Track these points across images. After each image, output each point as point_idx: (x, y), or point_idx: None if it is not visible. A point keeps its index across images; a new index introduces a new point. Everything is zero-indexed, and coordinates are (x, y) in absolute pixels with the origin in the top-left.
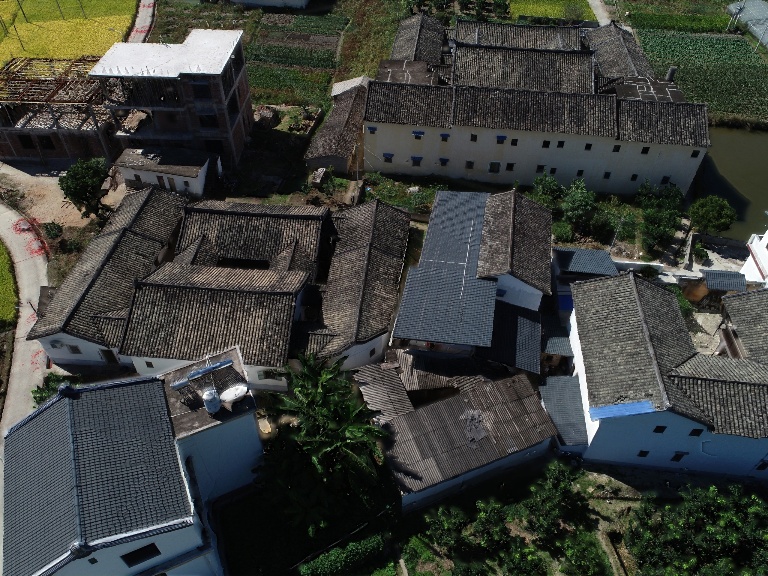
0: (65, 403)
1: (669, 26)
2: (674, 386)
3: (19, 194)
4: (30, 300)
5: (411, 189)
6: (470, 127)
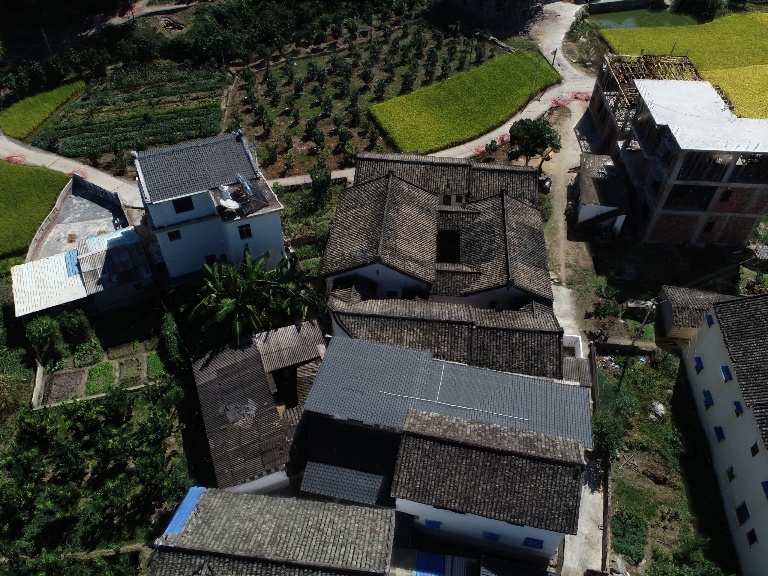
0: (233, 137)
1: None
2: (190, 571)
3: (546, 127)
4: None
5: (658, 405)
6: (760, 431)
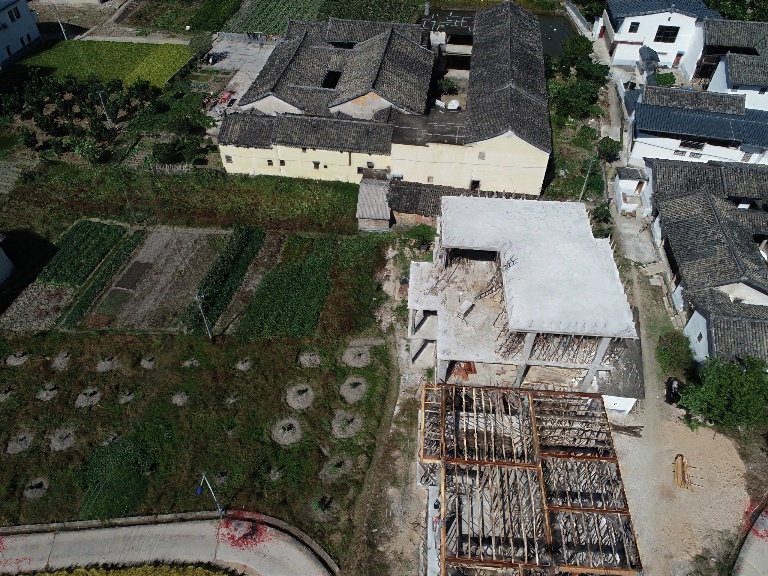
0: None
1: (224, 17)
2: None
3: (699, 567)
4: None
5: (564, 174)
6: None
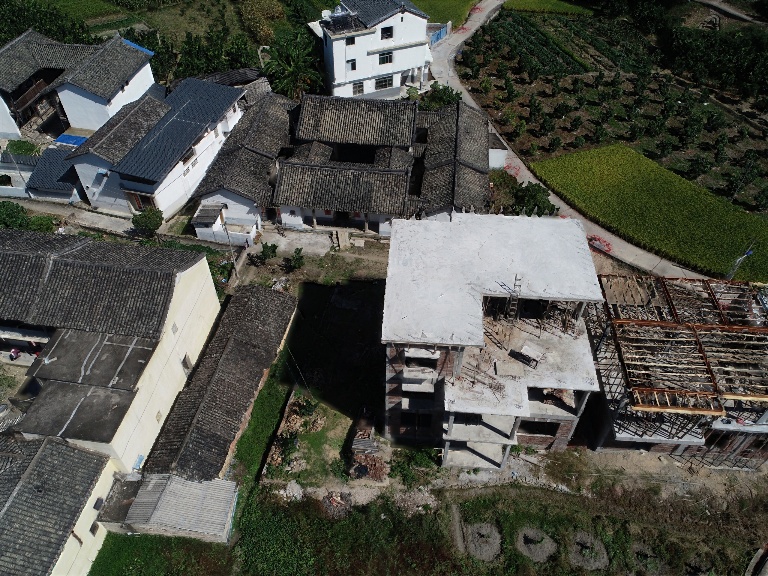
0: None
1: None
2: None
3: None
4: (530, 179)
5: None
6: None
